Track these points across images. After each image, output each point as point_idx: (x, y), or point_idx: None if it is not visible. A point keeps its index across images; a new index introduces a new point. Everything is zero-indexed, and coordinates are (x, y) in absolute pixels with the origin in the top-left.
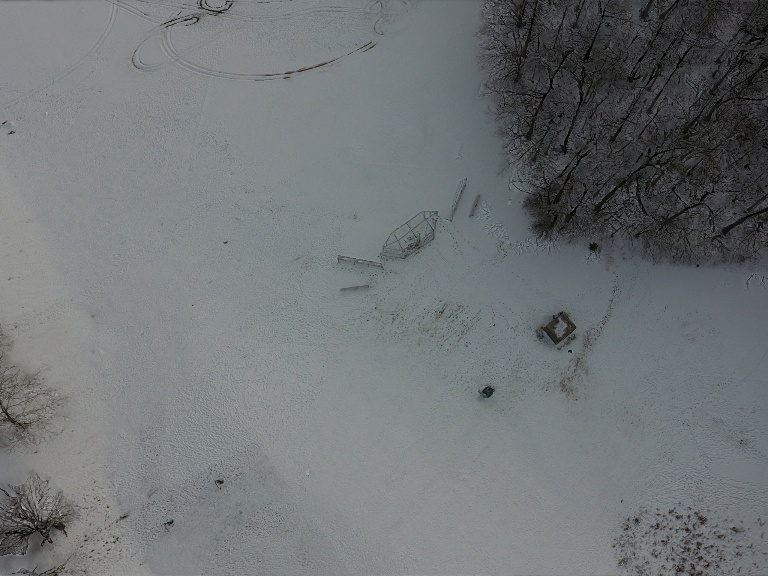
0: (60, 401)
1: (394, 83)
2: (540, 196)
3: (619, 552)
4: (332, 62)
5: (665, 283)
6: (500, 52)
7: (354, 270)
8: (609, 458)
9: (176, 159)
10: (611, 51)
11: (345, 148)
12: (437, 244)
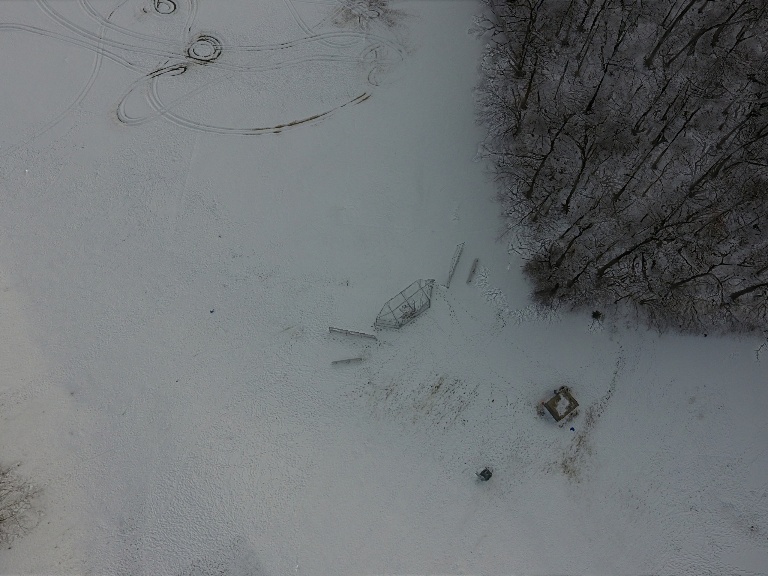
0: (35, 494)
1: (389, 138)
2: (541, 261)
3: None
4: (324, 115)
5: (671, 354)
6: (499, 109)
7: (346, 341)
8: (613, 547)
9: (161, 221)
10: (614, 102)
11: (337, 208)
12: (433, 313)
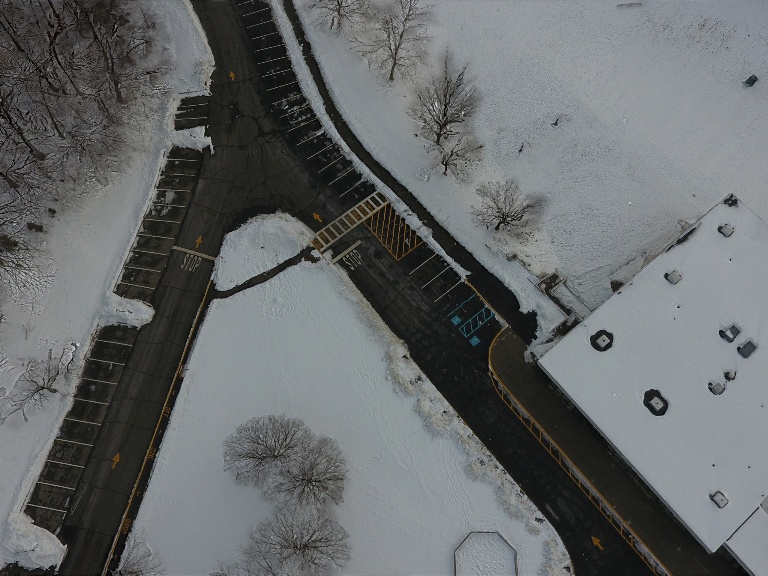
0: (425, 55)
1: None
2: None
3: None
4: None
5: None
6: None
7: None
8: None
9: None
10: None
11: None
12: None
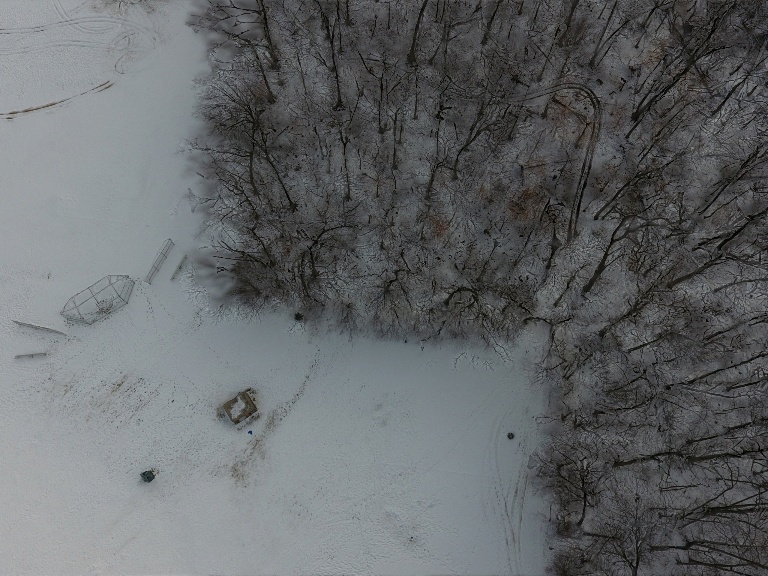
0: None
1: (123, 128)
2: None
3: None
4: (62, 102)
5: (368, 359)
6: (219, 102)
7: (35, 335)
8: (266, 553)
9: None
10: (366, 99)
11: (54, 199)
12: (130, 309)
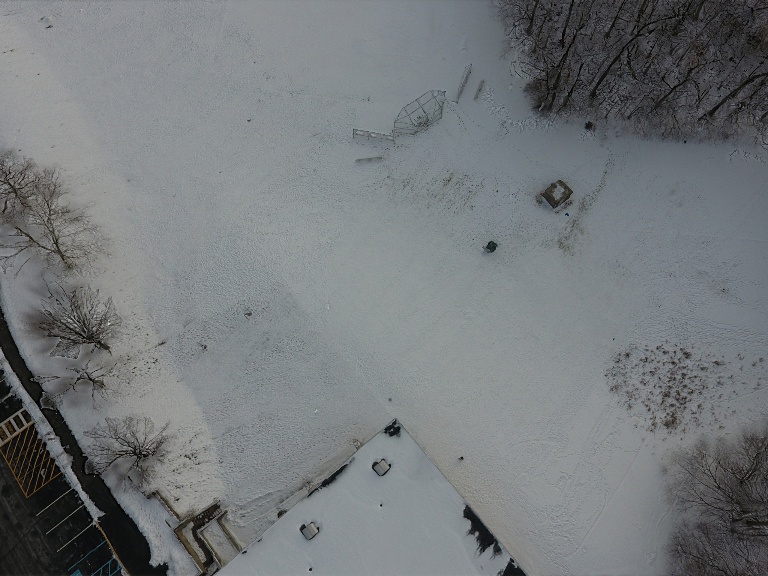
0: (103, 241)
1: None
2: (539, 81)
3: (611, 380)
4: None
5: (655, 157)
6: None
7: (368, 144)
8: (602, 304)
9: (202, 49)
10: None
11: (359, 40)
12: (444, 122)
